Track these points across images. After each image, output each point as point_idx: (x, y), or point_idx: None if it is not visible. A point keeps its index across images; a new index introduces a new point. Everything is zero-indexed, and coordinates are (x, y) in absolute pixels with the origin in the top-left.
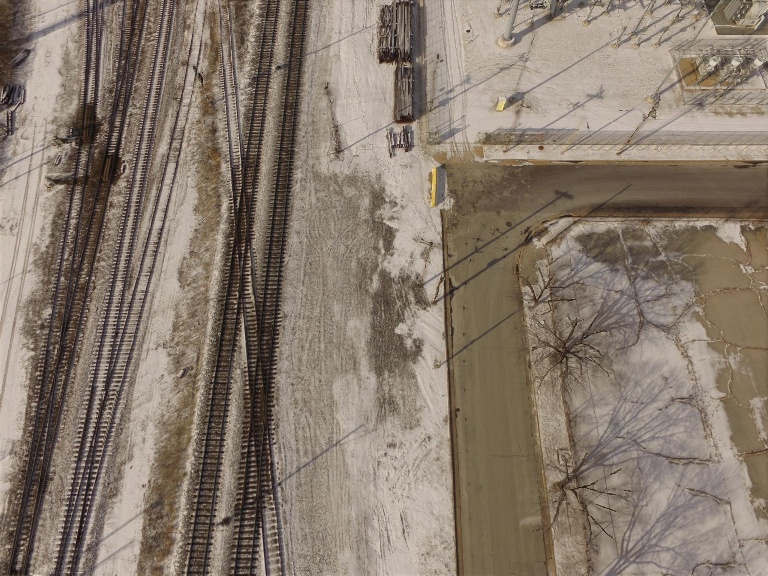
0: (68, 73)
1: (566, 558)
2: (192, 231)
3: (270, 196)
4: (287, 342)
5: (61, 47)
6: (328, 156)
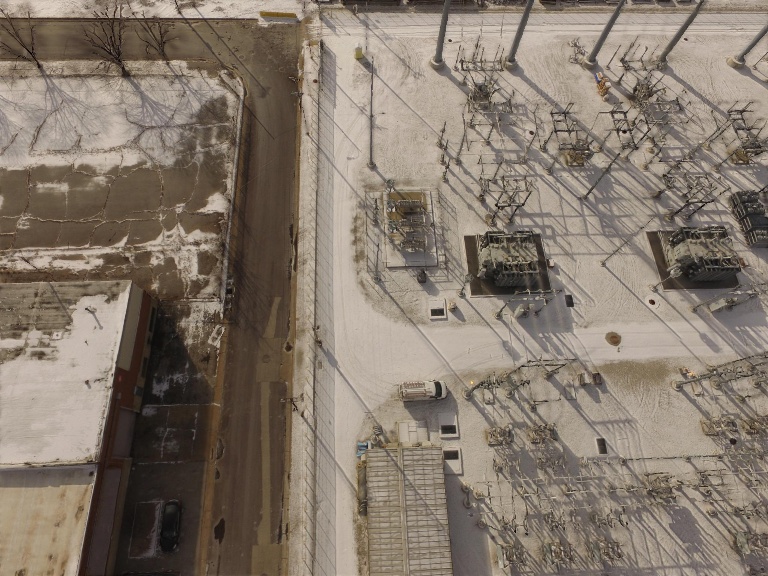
0: None
1: None
2: None
3: None
4: None
5: None
6: None
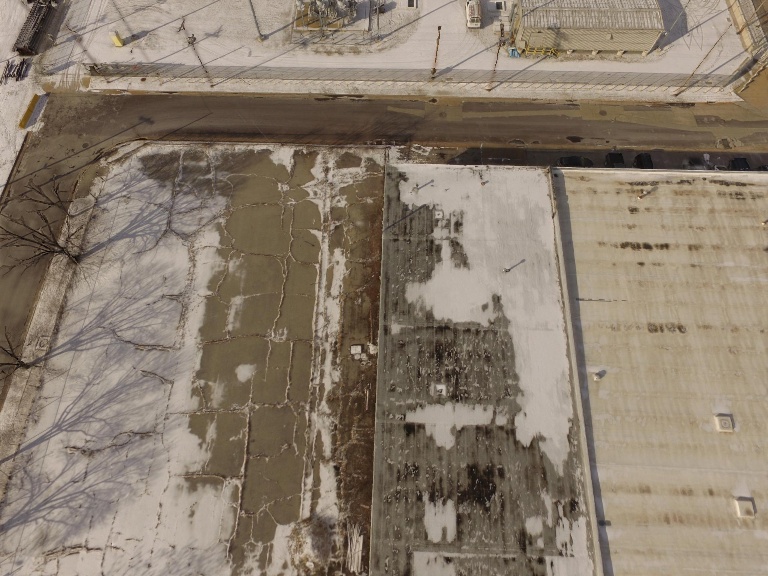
0: None
1: (5, 426)
2: None
3: None
4: None
5: None
6: None
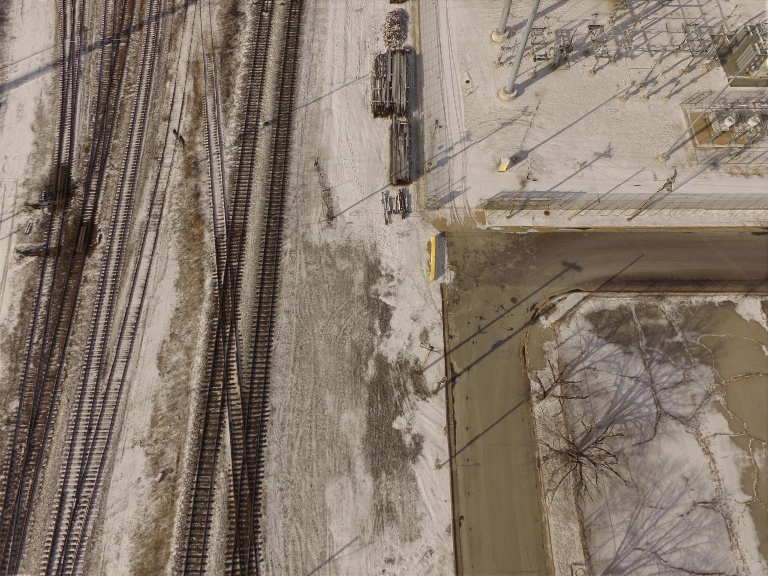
0: (41, 129)
1: None
2: (173, 310)
3: (257, 270)
4: (275, 440)
5: (34, 100)
6: (319, 224)
